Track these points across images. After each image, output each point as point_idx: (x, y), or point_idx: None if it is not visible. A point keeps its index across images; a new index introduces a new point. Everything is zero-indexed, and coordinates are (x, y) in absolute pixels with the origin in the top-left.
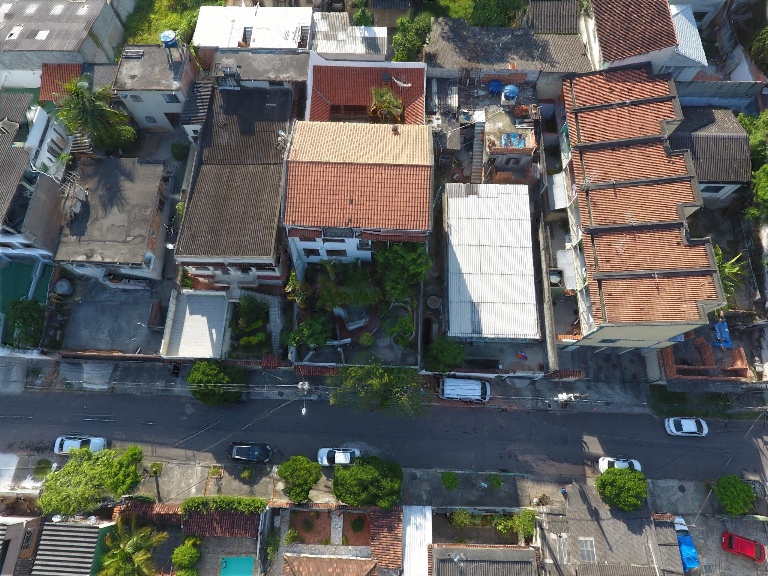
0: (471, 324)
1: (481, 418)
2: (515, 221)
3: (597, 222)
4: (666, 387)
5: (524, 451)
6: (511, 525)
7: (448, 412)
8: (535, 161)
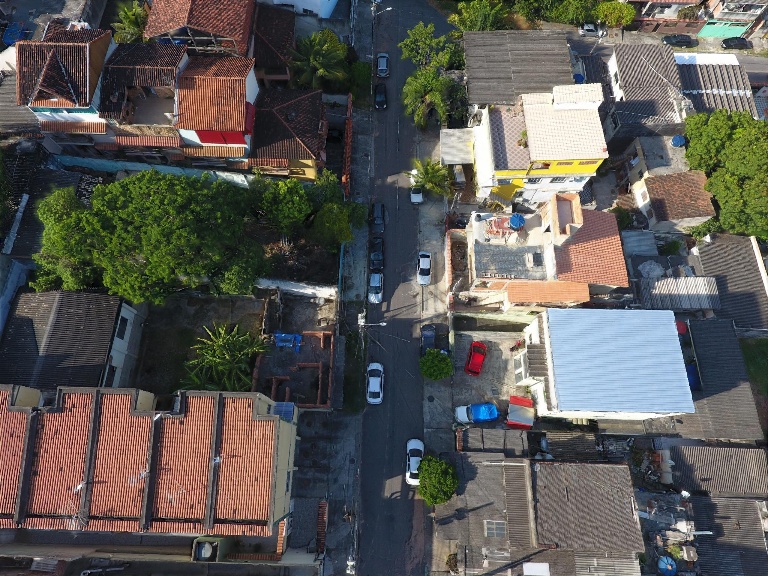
0: None
1: None
2: None
3: (137, 512)
4: None
5: (402, 573)
6: None
7: None
8: (29, 563)
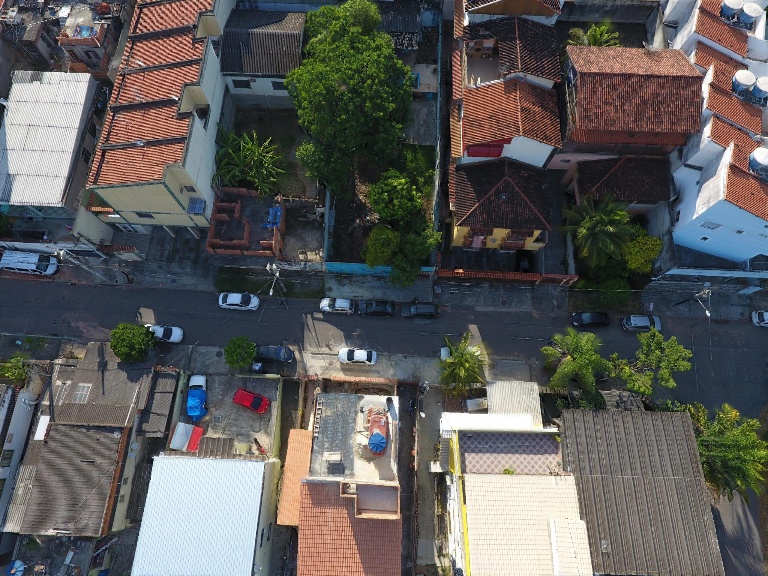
0: (2, 193)
1: (46, 290)
2: (69, 105)
3: (121, 101)
4: (233, 268)
5: (78, 319)
6: (19, 372)
7: (17, 284)
8: None
